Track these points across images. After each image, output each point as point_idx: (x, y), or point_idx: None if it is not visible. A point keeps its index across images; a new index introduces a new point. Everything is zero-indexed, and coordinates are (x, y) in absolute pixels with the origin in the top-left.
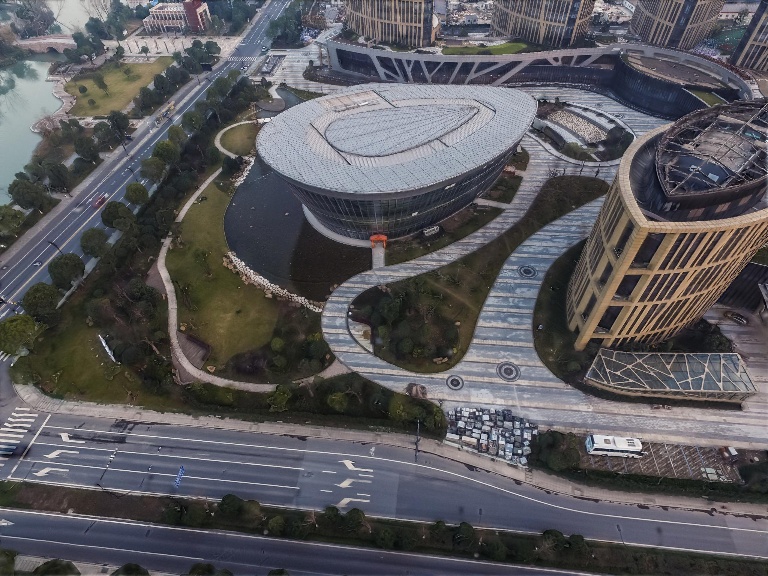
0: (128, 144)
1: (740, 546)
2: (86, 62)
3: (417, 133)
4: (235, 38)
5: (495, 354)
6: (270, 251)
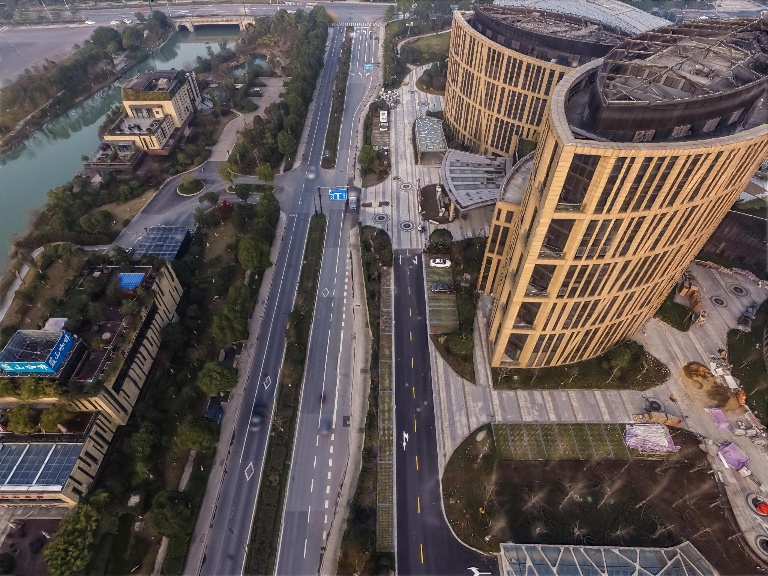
0: None
1: (342, 151)
2: None
3: None
4: (764, 8)
5: (434, 101)
6: None
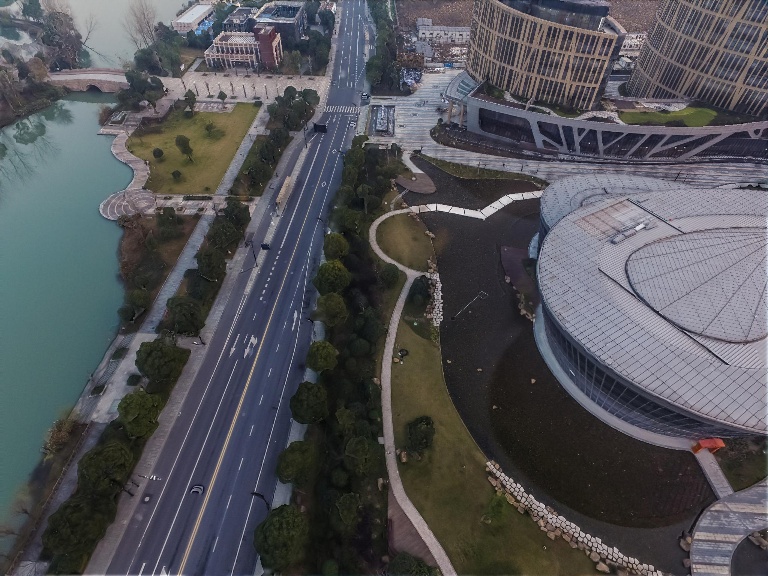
0: (249, 245)
1: None
2: (145, 109)
3: (759, 288)
4: (320, 79)
5: None
6: (546, 458)
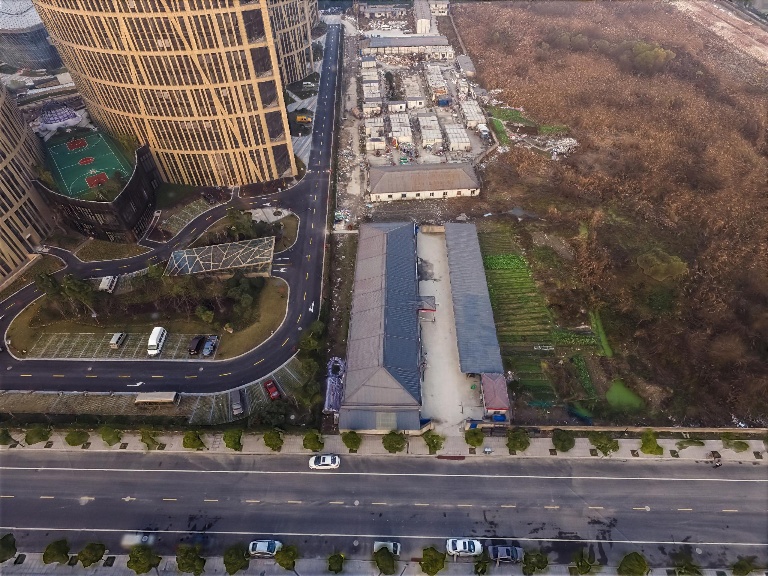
0: None
1: None
2: None
3: None
4: None
5: None
6: None
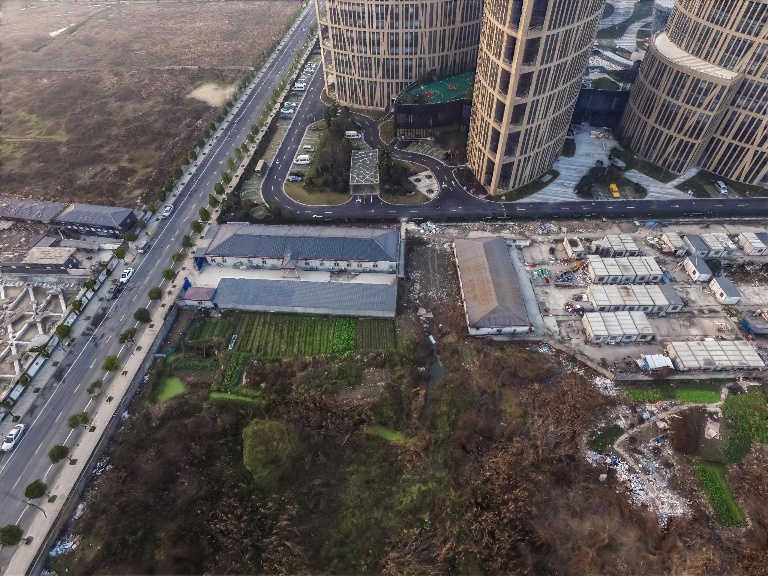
0: None
1: None
2: None
3: None
4: None
5: (625, 3)
6: None
